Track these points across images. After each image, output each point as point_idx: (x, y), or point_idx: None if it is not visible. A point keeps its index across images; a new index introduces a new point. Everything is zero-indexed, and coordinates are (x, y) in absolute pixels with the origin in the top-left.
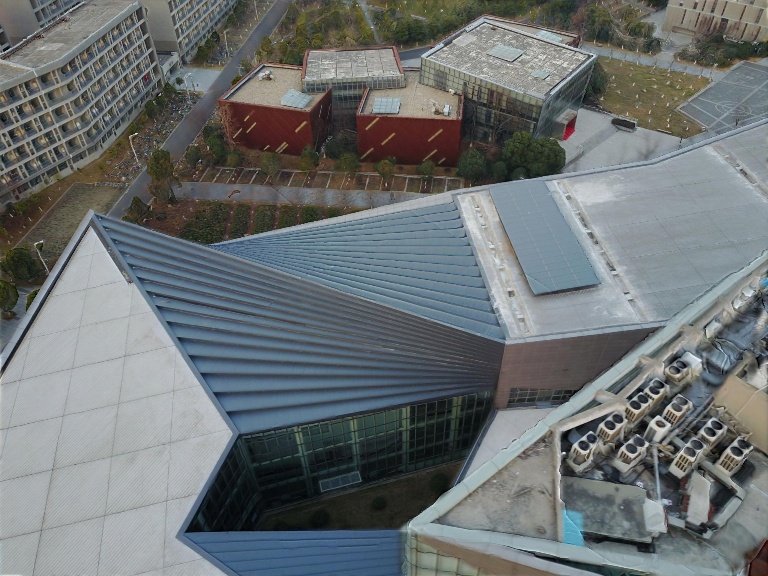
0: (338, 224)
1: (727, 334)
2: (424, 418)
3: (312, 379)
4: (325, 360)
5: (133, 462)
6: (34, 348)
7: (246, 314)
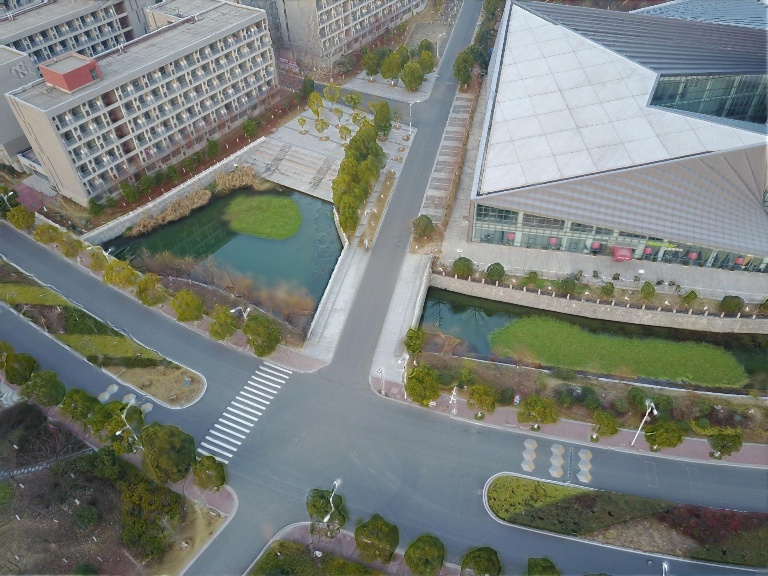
0: (662, 7)
1: None
2: (743, 90)
3: (686, 60)
4: (690, 53)
5: (605, 86)
6: (515, 52)
7: (634, 36)
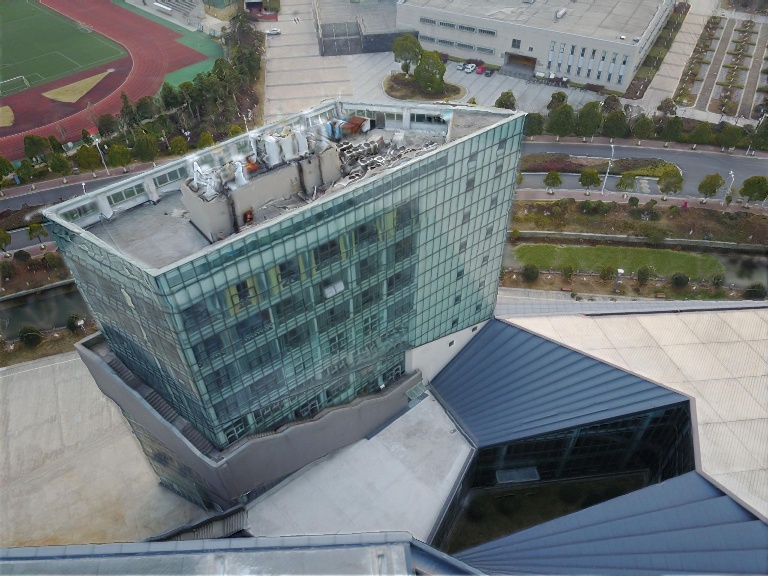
0: None
1: (301, 205)
2: None
3: (650, 551)
4: None
5: None
6: None
7: None
